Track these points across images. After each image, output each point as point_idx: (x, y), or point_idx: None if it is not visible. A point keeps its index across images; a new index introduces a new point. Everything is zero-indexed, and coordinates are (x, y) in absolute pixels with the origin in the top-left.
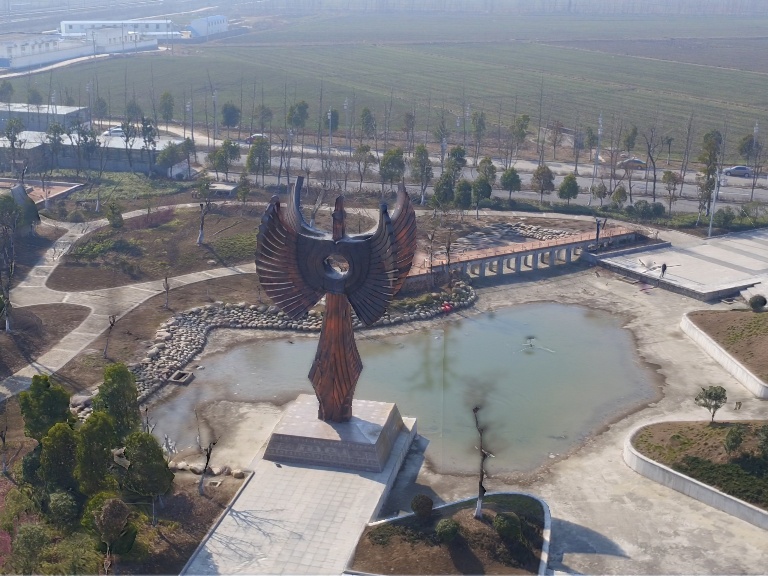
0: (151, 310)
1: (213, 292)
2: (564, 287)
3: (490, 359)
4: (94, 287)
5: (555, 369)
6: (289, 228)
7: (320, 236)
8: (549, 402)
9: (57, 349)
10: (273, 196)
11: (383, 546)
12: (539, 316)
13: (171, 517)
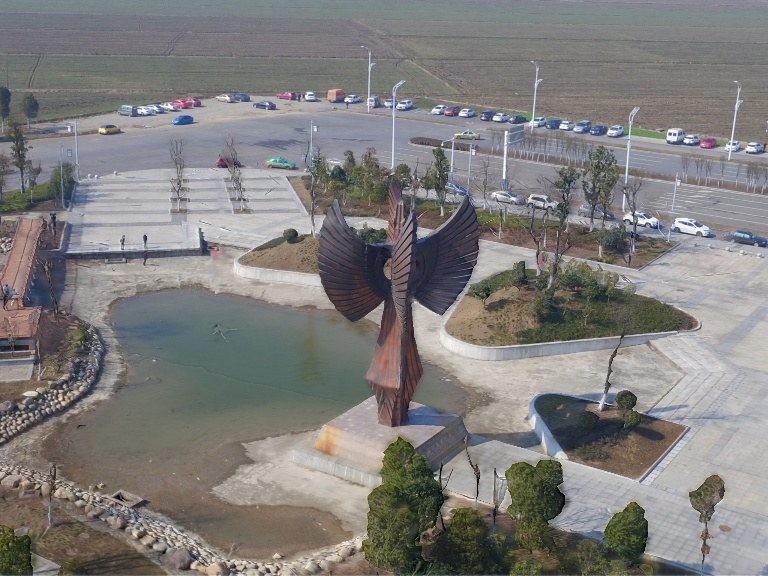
0: None
1: None
2: (95, 285)
3: (225, 355)
4: None
5: (274, 338)
6: None
7: (386, 248)
8: (342, 357)
9: None
10: (412, 214)
11: (610, 458)
12: (149, 312)
13: None
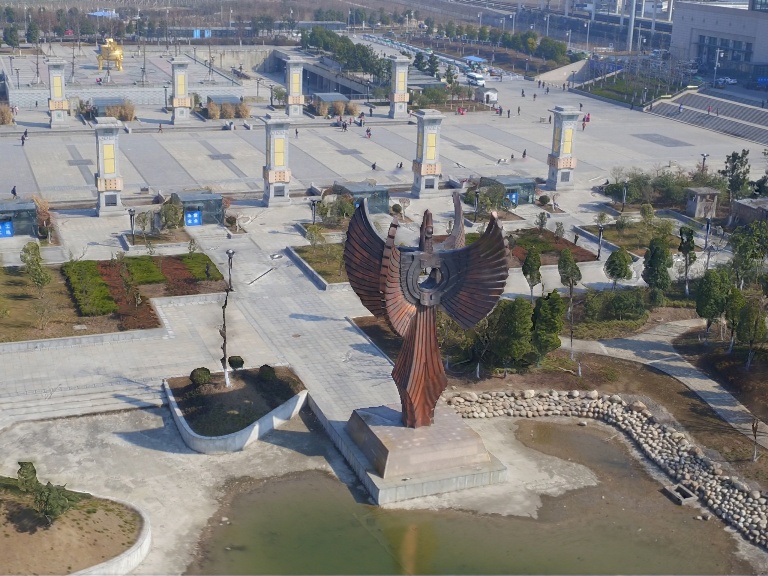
0: None
1: None
2: None
3: None
4: None
5: None
6: None
7: None
8: None
9: None
10: None
11: None
12: None
13: None
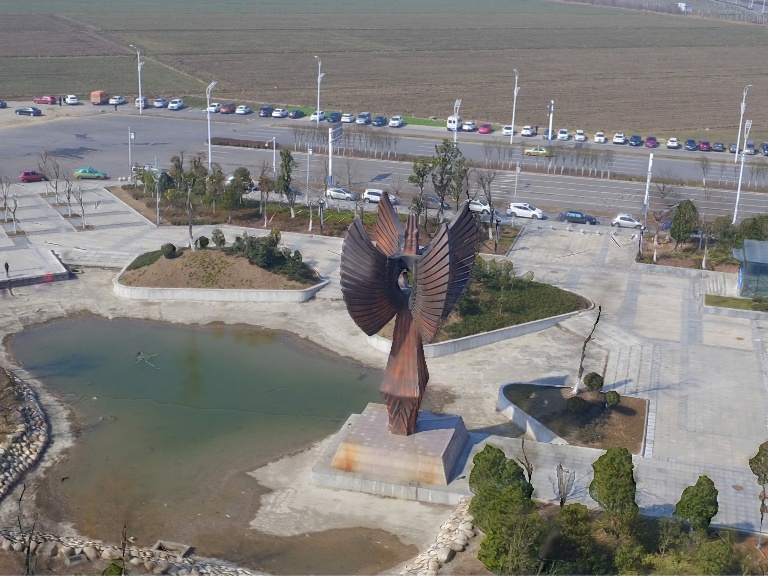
0: None
1: None
2: None
3: (163, 383)
4: None
5: (202, 360)
6: None
7: (402, 259)
8: (283, 371)
9: None
10: None
11: (606, 438)
12: (52, 347)
13: None
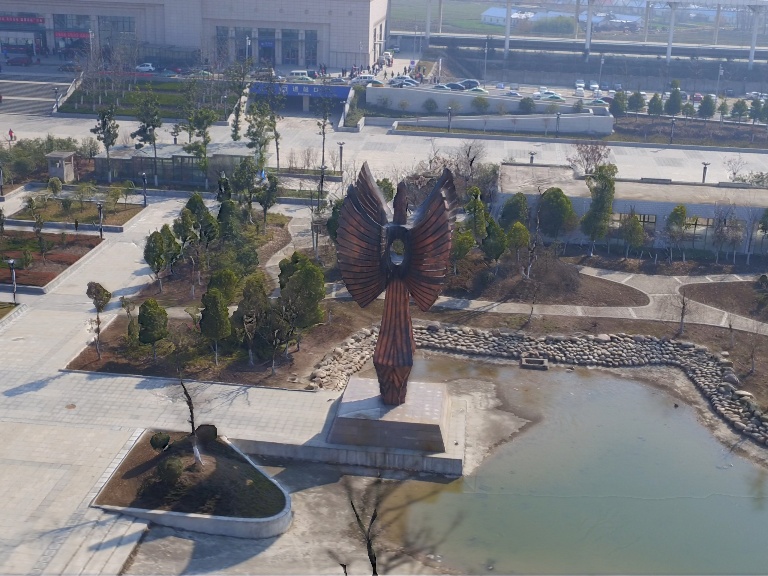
0: (667, 327)
1: (757, 348)
2: None
3: (741, 531)
4: (707, 301)
5: None
6: (379, 199)
7: None
8: (609, 568)
9: (535, 306)
10: None
11: None
12: None
13: (236, 369)
